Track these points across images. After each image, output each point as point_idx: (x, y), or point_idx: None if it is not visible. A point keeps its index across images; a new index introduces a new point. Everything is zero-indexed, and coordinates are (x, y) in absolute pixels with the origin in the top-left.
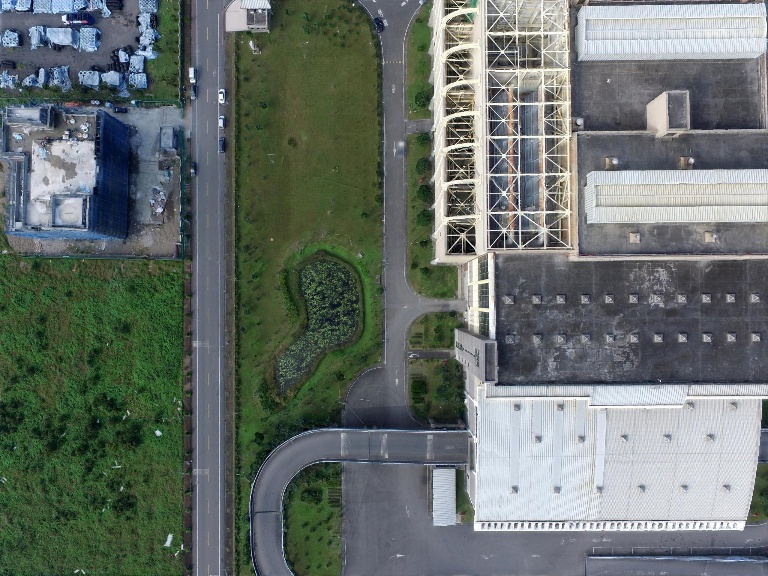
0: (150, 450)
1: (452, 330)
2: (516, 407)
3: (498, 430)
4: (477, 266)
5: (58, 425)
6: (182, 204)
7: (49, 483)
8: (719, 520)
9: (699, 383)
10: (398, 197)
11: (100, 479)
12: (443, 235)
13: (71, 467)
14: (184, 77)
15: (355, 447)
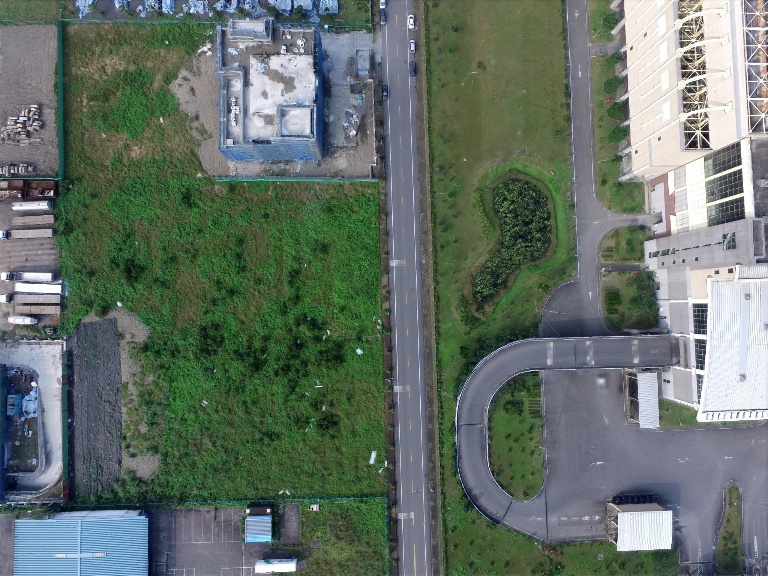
0: (352, 369)
1: (642, 243)
2: (747, 296)
3: (729, 319)
4: (703, 165)
5: (259, 346)
6: (376, 126)
7: (252, 404)
8: None
9: None
10: (585, 117)
11: (302, 399)
12: (674, 134)
13: (273, 388)
14: (373, 3)
15: (561, 355)
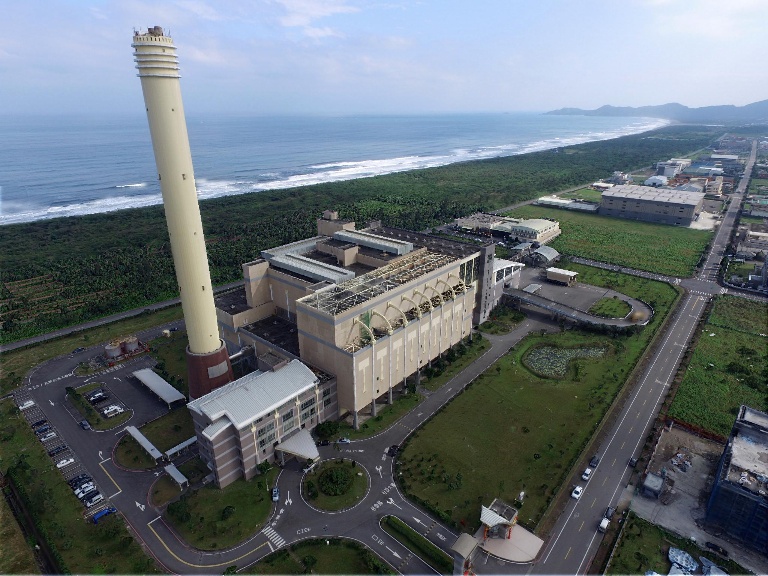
0: None
1: None
2: None
3: None
4: None
5: None
6: None
7: None
8: None
9: (414, 232)
10: (467, 373)
11: None
12: None
13: None
14: (617, 531)
15: None
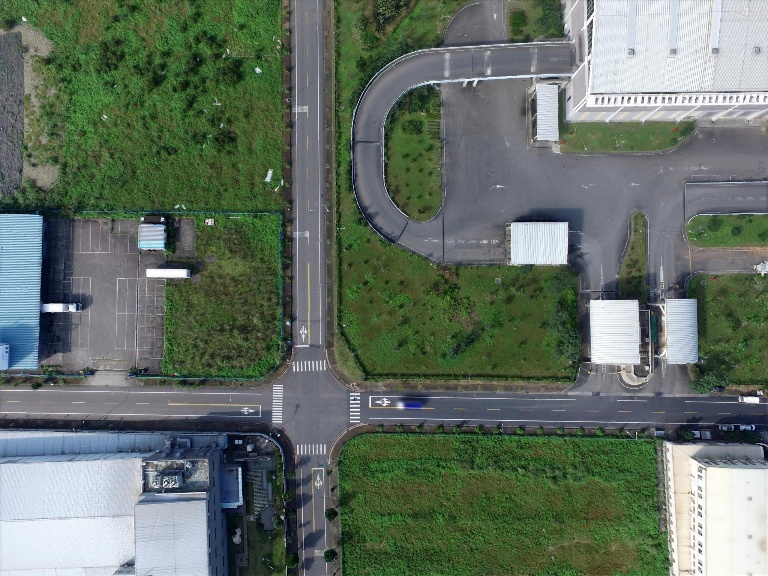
0: (250, 87)
1: None
2: None
3: None
4: None
5: (158, 62)
6: None
7: (150, 118)
8: None
9: None
10: None
11: (200, 115)
12: None
13: (171, 104)
14: None
15: (458, 67)
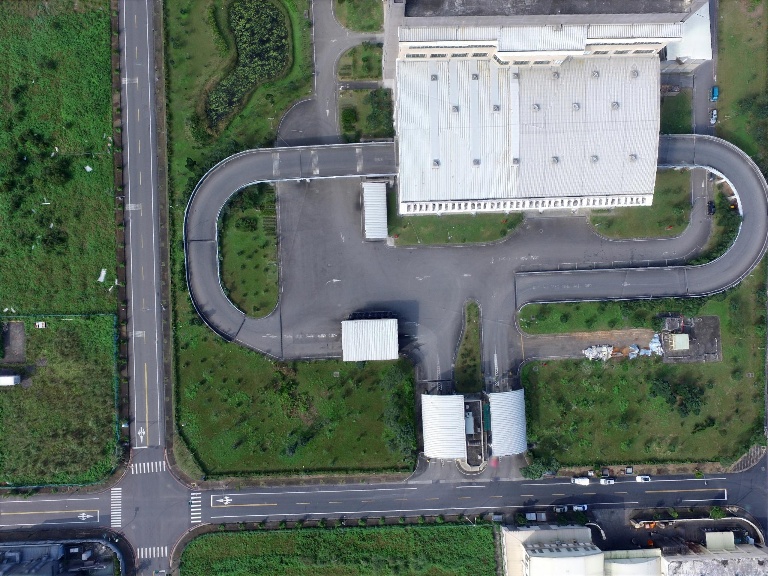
0: (80, 186)
1: (380, 61)
2: (433, 75)
3: (417, 101)
4: None
5: None
6: None
7: None
8: (629, 194)
9: (595, 14)
10: None
11: (28, 216)
12: None
13: None
14: None
15: (287, 166)
